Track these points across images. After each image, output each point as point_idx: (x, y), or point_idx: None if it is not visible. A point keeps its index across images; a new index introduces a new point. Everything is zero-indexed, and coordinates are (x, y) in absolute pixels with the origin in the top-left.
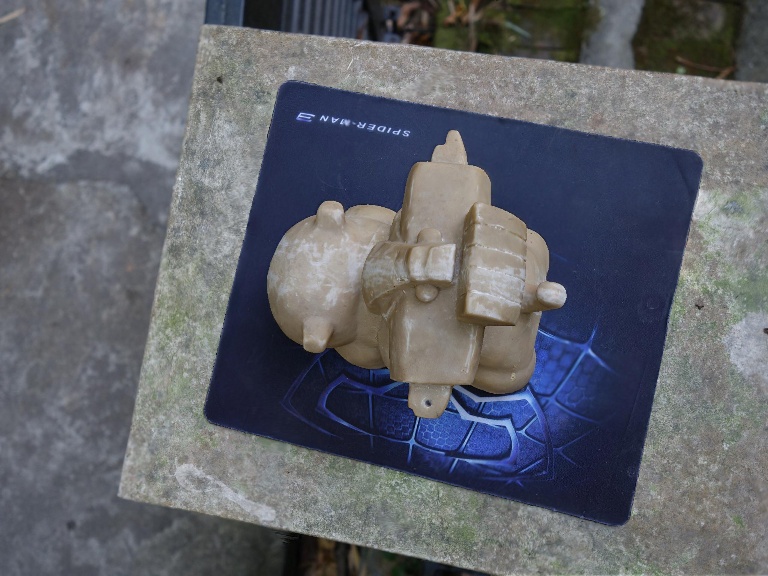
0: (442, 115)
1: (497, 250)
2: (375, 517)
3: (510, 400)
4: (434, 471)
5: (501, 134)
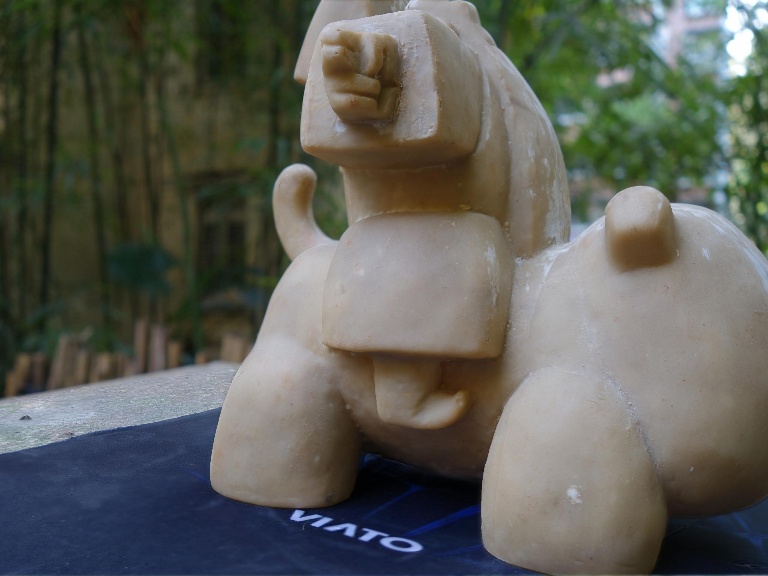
0: None
1: None
2: None
3: None
4: None
5: None
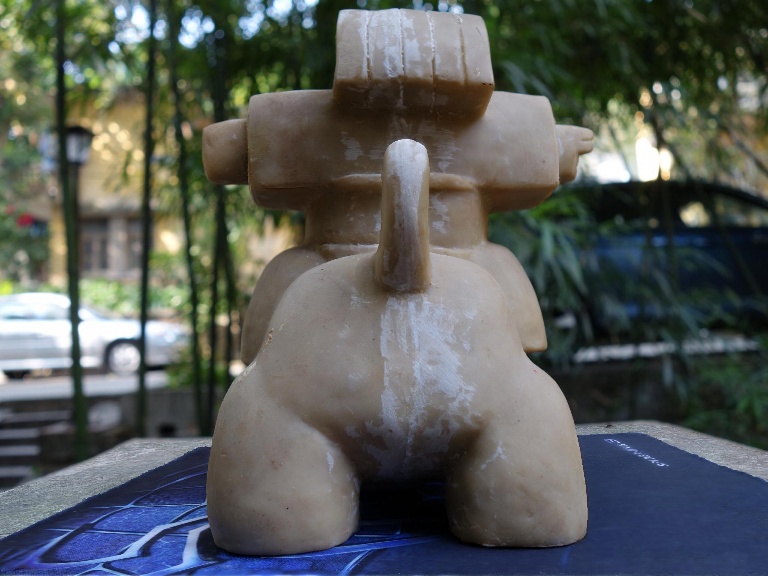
0: (728, 474)
1: (428, 16)
2: (6, 508)
3: (185, 552)
4: (60, 521)
5: (766, 496)
